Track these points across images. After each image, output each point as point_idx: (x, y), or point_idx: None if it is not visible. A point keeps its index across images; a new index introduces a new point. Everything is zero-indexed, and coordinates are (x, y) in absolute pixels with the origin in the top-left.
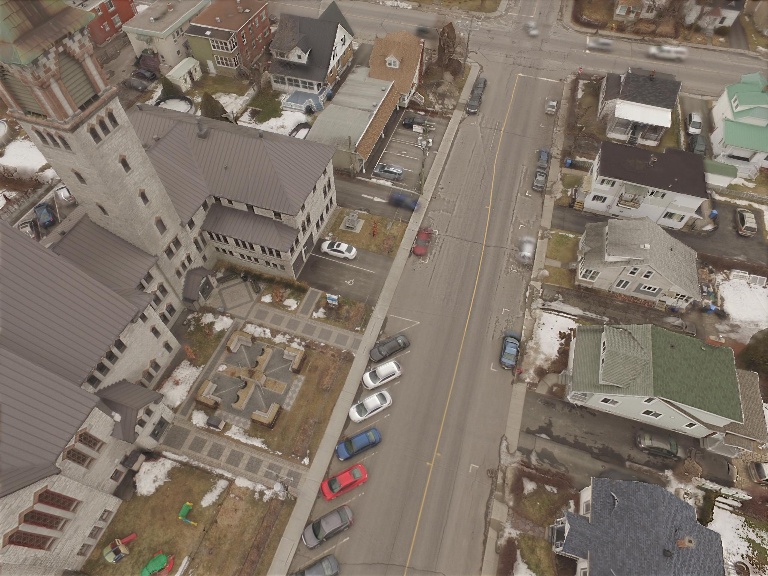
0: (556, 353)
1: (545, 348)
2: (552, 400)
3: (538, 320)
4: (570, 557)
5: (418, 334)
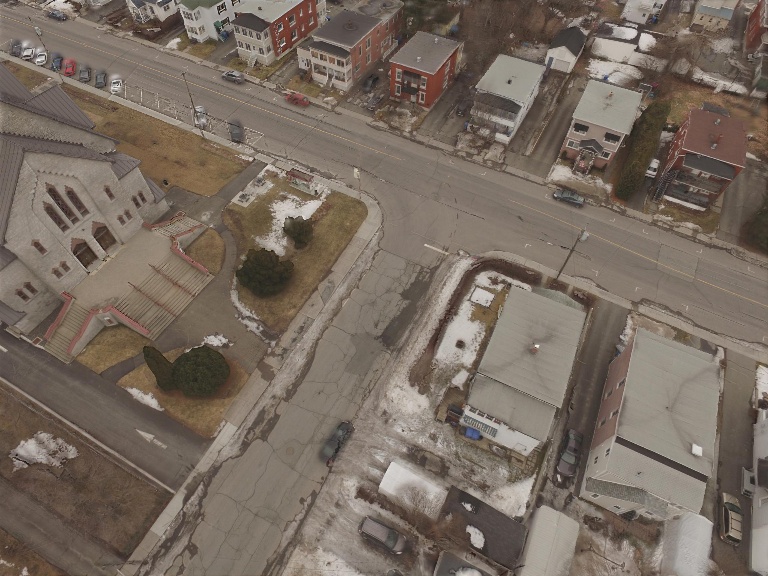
0: (72, 5)
1: (66, 7)
2: (89, 7)
3: (51, 7)
4: (148, 19)
5: (18, 40)
